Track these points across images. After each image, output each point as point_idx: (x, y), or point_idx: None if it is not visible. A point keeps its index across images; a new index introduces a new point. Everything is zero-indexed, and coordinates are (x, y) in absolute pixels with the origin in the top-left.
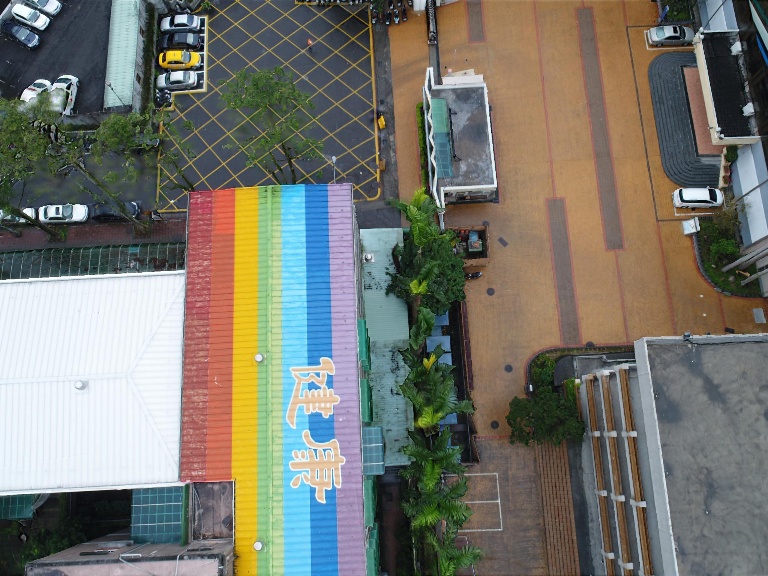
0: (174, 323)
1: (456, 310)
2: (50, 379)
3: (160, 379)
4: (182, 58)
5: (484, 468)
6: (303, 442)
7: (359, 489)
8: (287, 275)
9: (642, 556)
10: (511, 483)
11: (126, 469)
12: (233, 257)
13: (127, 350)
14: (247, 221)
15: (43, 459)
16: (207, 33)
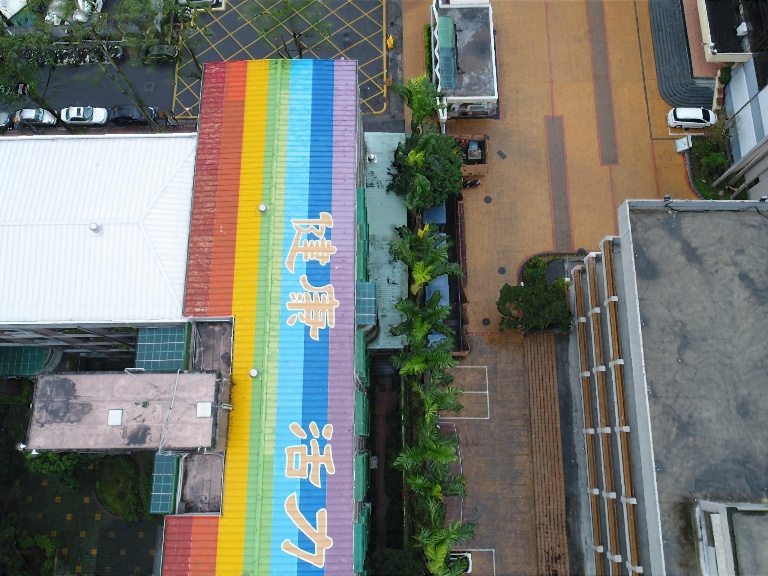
0: (185, 179)
1: (454, 214)
2: (67, 222)
3: (169, 227)
4: None
5: (474, 361)
6: (300, 285)
7: (351, 330)
8: (292, 138)
9: (618, 409)
10: (500, 376)
11: (134, 306)
12: (243, 121)
13: (140, 200)
14: (257, 89)
15: (57, 294)
16: None
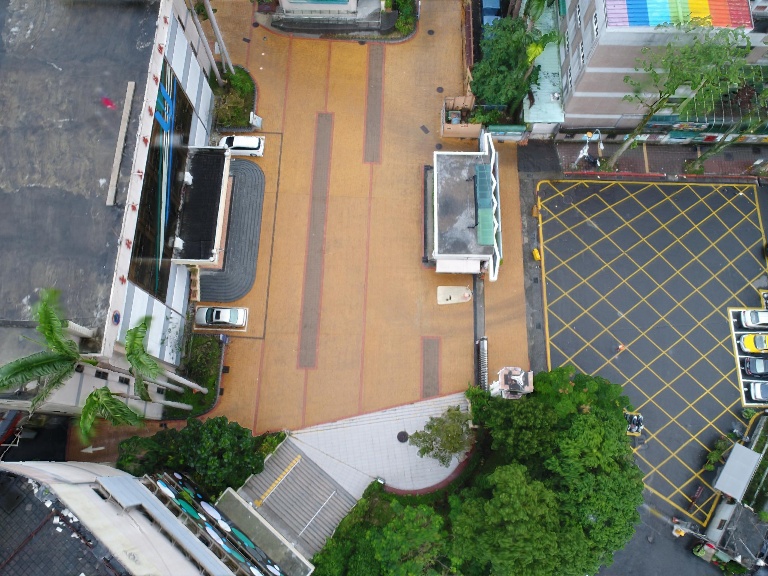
0: None
1: None
2: None
3: None
4: (764, 339)
5: None
6: None
7: None
8: None
9: None
10: None
11: None
12: None
13: None
14: (697, 1)
15: None
16: (740, 383)
